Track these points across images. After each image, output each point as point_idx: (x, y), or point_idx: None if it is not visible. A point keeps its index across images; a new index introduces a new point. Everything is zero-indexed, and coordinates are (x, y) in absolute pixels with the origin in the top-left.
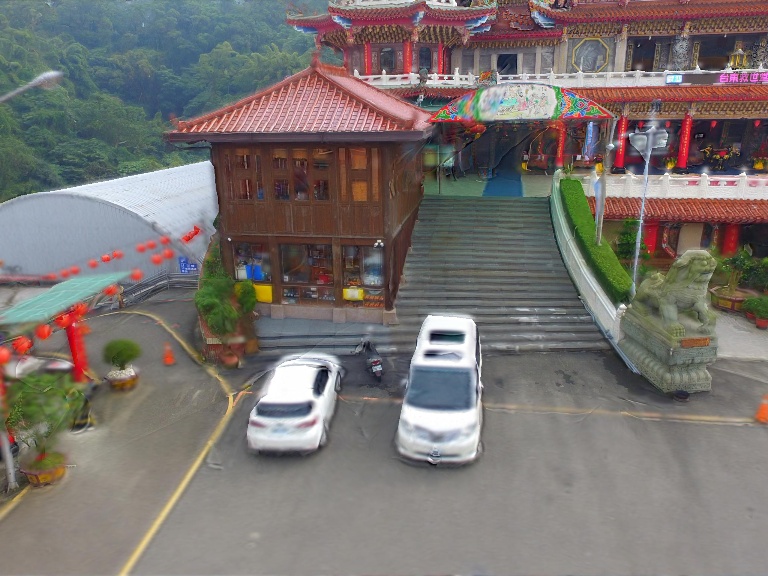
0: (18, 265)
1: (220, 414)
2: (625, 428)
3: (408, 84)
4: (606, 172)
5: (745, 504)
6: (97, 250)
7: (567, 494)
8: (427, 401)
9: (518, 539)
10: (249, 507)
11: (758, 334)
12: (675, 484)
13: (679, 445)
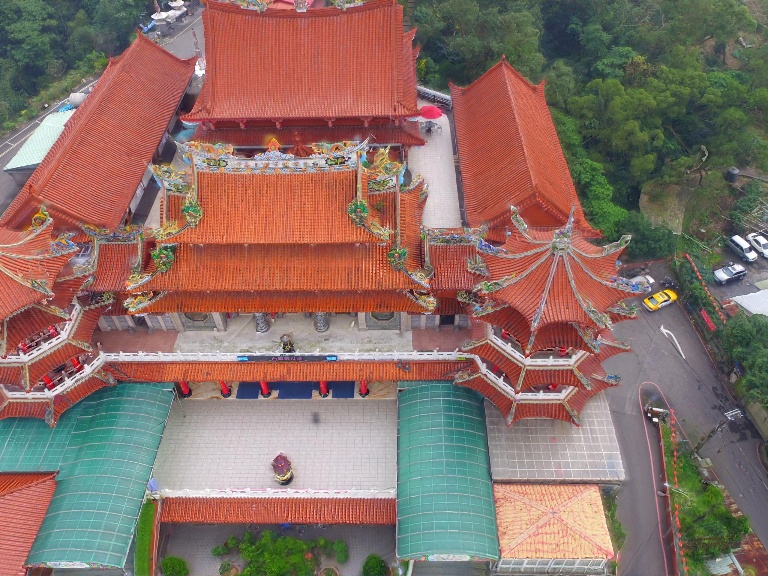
0: None
1: None
2: None
3: (46, 398)
4: (220, 391)
5: None
6: None
7: None
8: None
9: None
10: None
11: None
12: None
13: None
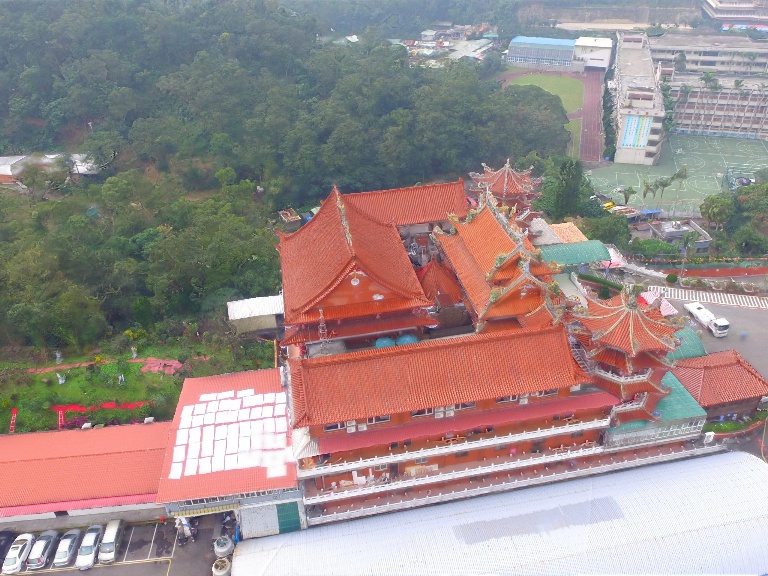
0: None
1: None
2: None
3: None
4: None
5: None
6: None
7: None
8: None
9: None
10: None
11: None
12: None
13: None
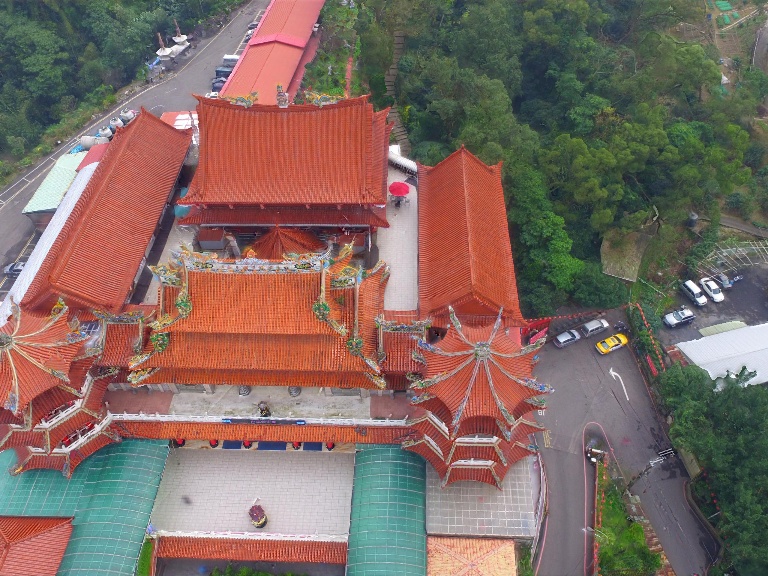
0: None
1: None
2: None
3: (64, 453)
4: (209, 441)
5: None
6: None
7: None
8: None
9: None
10: None
11: None
12: None
13: None
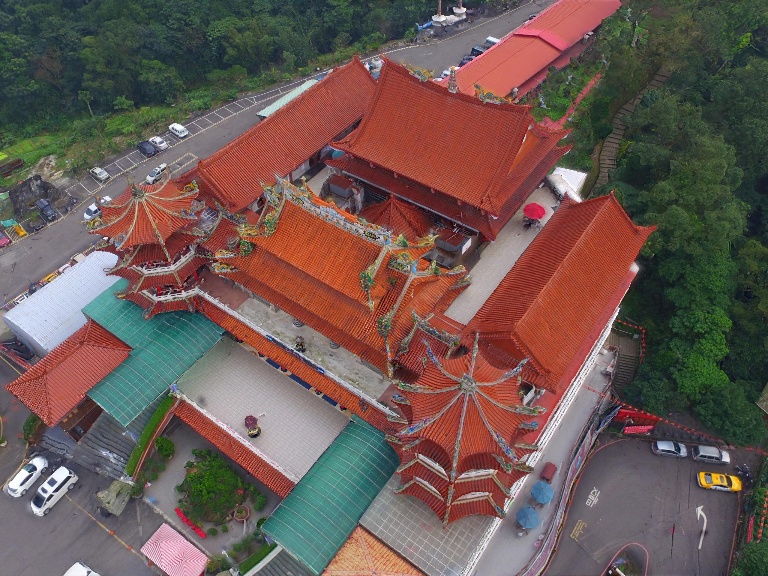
0: (19, 333)
1: (17, 468)
2: (79, 521)
3: (153, 300)
4: None
5: (74, 553)
6: (36, 345)
7: (51, 533)
8: (36, 500)
9: (31, 540)
10: (0, 507)
11: (175, 494)
12: (71, 541)
13: (87, 530)
